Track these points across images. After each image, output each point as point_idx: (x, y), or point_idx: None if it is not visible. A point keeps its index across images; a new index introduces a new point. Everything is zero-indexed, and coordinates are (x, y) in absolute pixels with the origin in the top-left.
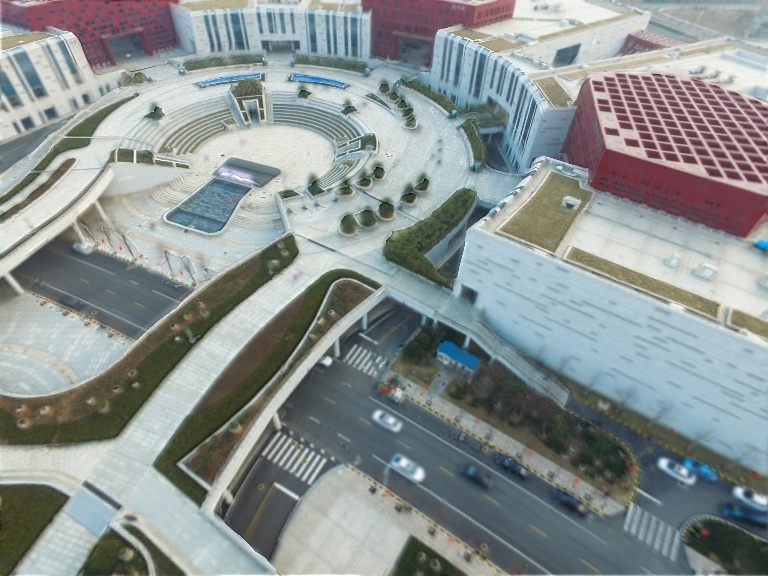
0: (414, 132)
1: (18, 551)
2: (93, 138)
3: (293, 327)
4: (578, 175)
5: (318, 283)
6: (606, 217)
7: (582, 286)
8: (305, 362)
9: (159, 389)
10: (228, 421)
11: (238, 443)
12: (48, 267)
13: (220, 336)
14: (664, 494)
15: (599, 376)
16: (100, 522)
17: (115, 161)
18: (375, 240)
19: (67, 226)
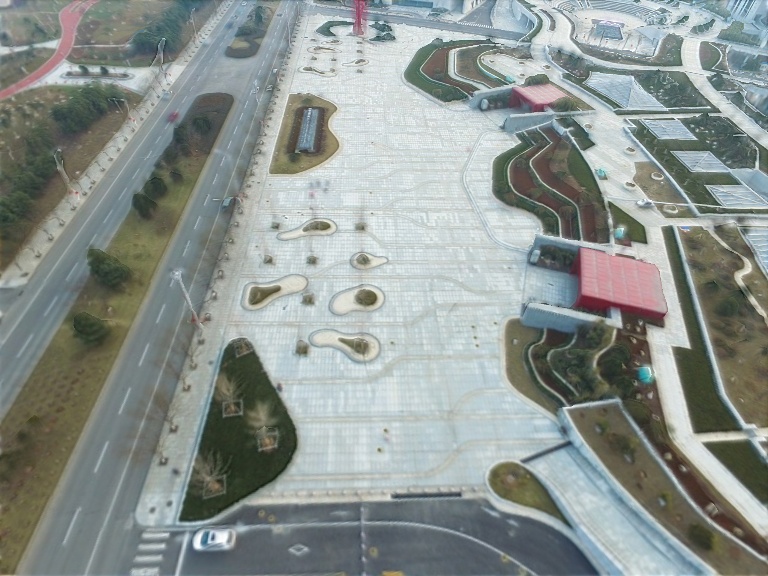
0: None
1: None
2: None
3: None
4: None
5: None
6: None
7: None
8: None
9: (682, 58)
10: None
11: None
12: None
13: None
14: None
15: None
16: None
17: (564, 10)
18: (709, 36)
19: None
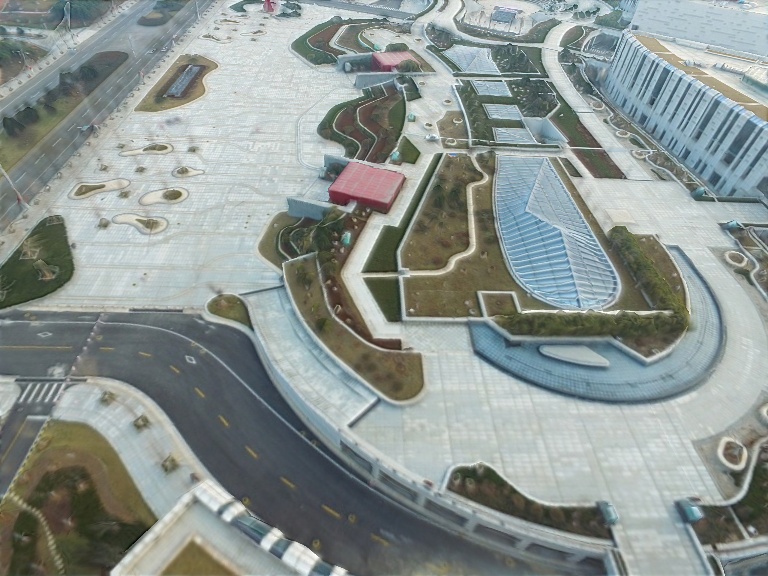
0: (578, 0)
1: None
2: None
3: None
4: None
5: None
6: None
7: (684, 7)
8: None
9: (547, 37)
10: (575, 41)
11: (582, 44)
12: None
13: None
14: None
15: None
16: (555, 51)
17: None
18: None
19: None
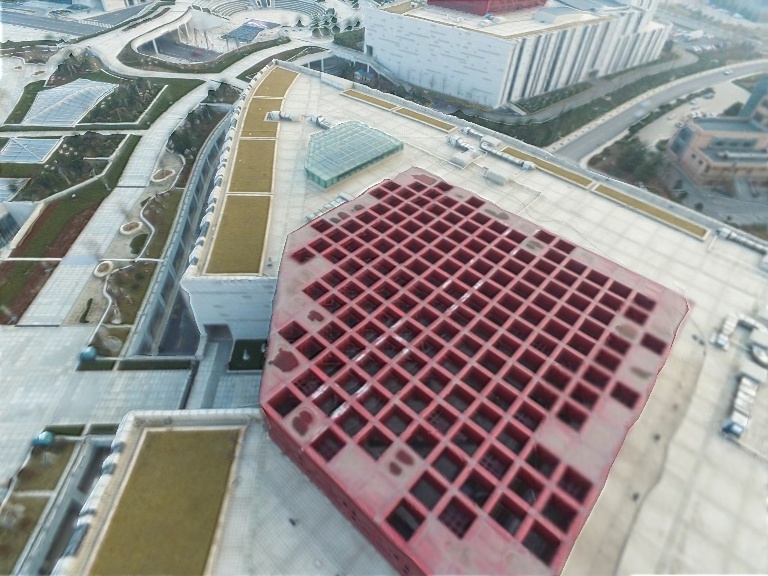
0: (357, 11)
1: (193, 87)
2: (176, 2)
3: (289, 54)
4: (423, 1)
5: (300, 47)
6: (429, 11)
7: (408, 24)
8: (294, 61)
9: (234, 65)
10: None
11: None
12: (166, 47)
13: (257, 55)
14: (440, 109)
15: (422, 75)
16: (219, 85)
17: (192, 9)
18: (329, 40)
19: (175, 29)
